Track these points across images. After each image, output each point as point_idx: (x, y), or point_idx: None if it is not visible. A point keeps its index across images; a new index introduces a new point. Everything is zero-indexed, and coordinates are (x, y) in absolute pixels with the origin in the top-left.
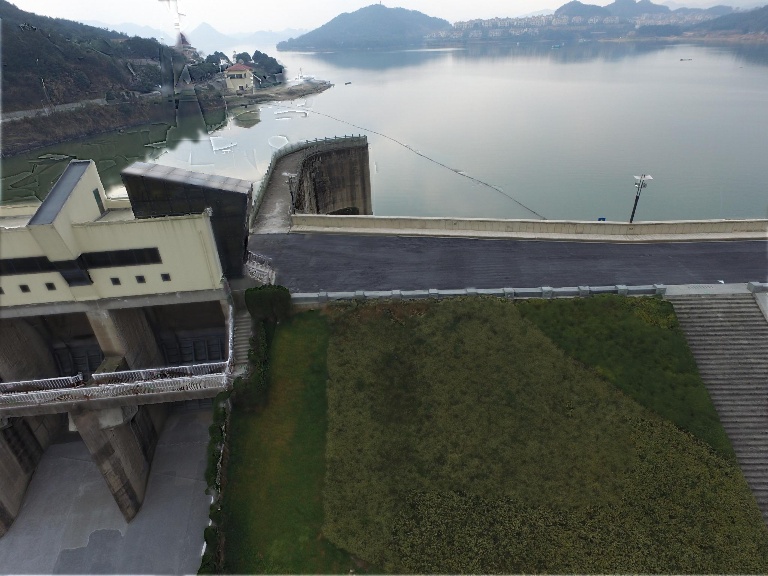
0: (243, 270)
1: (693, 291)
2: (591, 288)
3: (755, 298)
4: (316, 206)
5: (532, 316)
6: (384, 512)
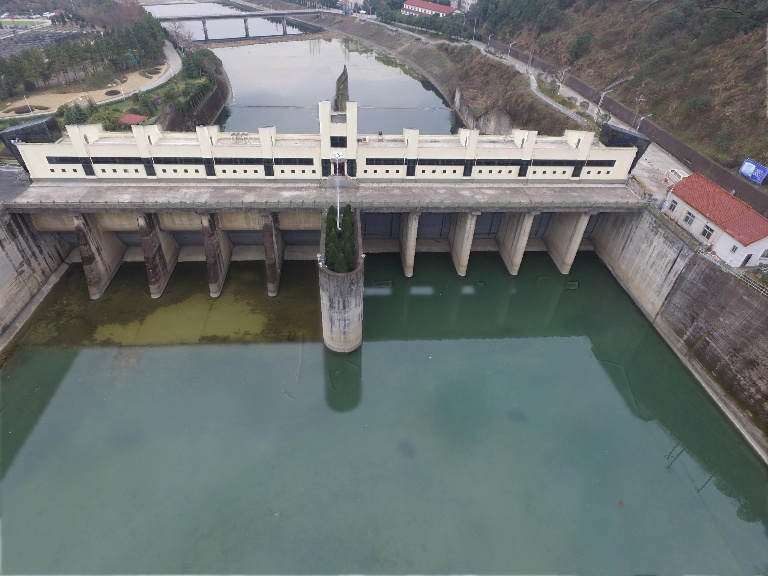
0: None
1: None
2: None
3: None
4: None
5: None
6: None
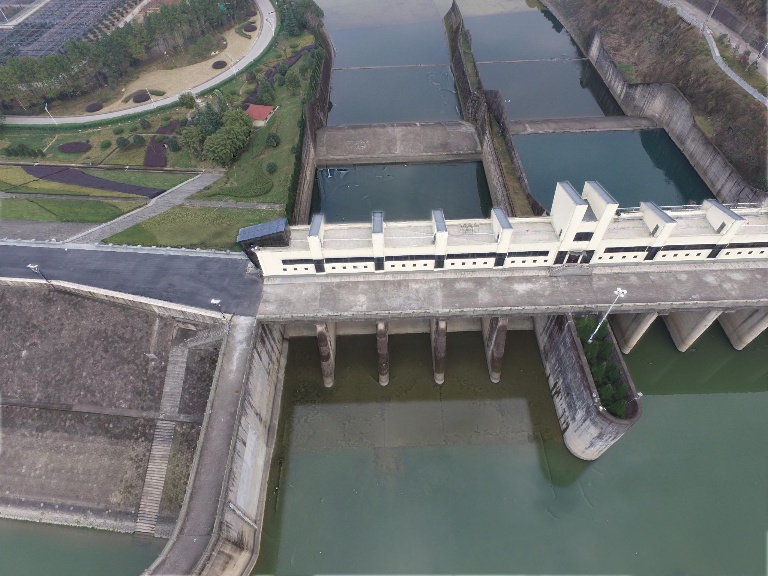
0: None
1: (85, 245)
2: (121, 247)
3: (67, 242)
4: None
5: (155, 241)
6: None
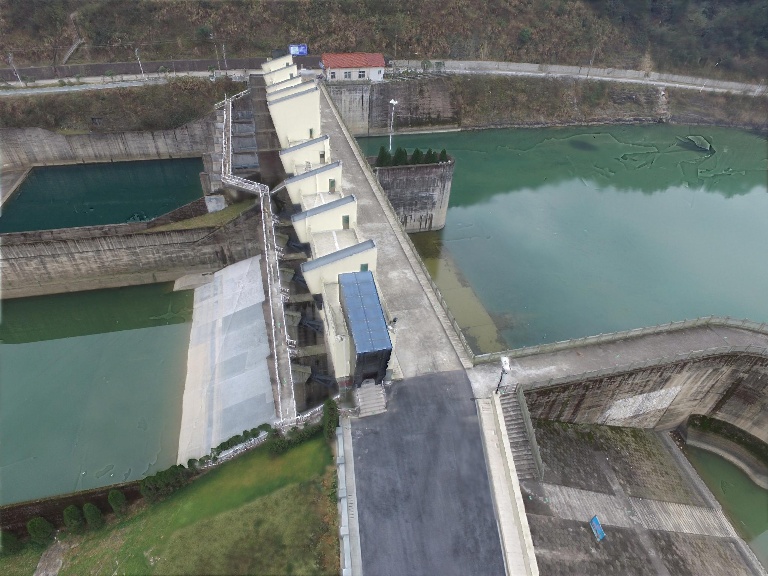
0: (355, 387)
1: None
2: None
3: None
4: (716, 404)
5: None
6: (177, 572)
